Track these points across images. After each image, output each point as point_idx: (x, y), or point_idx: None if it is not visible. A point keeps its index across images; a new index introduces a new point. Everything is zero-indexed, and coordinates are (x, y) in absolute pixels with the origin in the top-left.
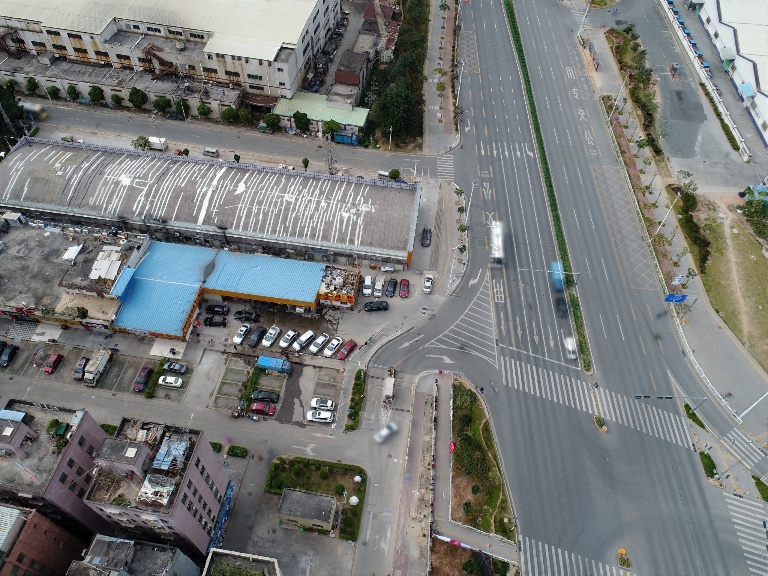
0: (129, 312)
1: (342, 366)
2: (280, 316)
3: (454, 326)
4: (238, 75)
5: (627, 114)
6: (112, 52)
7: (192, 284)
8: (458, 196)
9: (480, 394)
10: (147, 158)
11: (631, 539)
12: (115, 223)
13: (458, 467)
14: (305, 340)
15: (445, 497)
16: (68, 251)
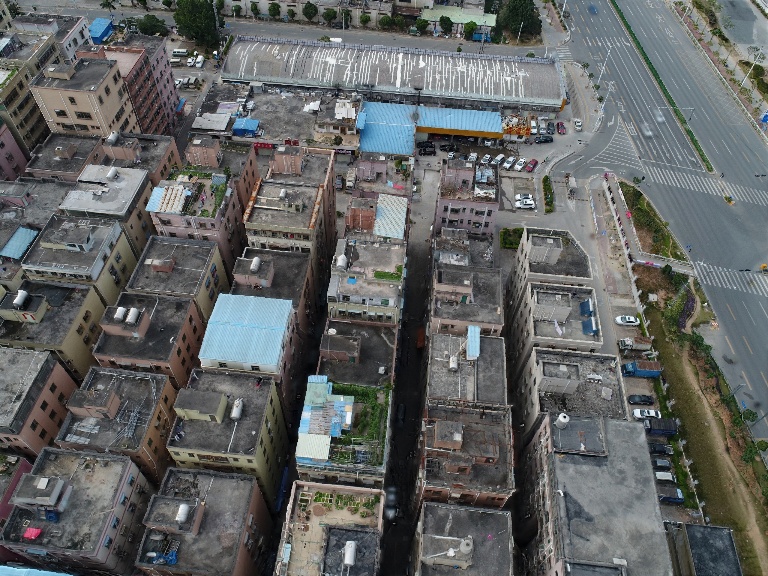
0: (367, 143)
1: (530, 176)
2: (473, 148)
3: (605, 150)
4: None
5: (695, 17)
6: None
7: (407, 125)
8: (584, 69)
9: (638, 187)
10: (338, 48)
11: (767, 261)
12: (329, 91)
13: (638, 224)
14: (500, 159)
15: (633, 242)
16: (306, 107)
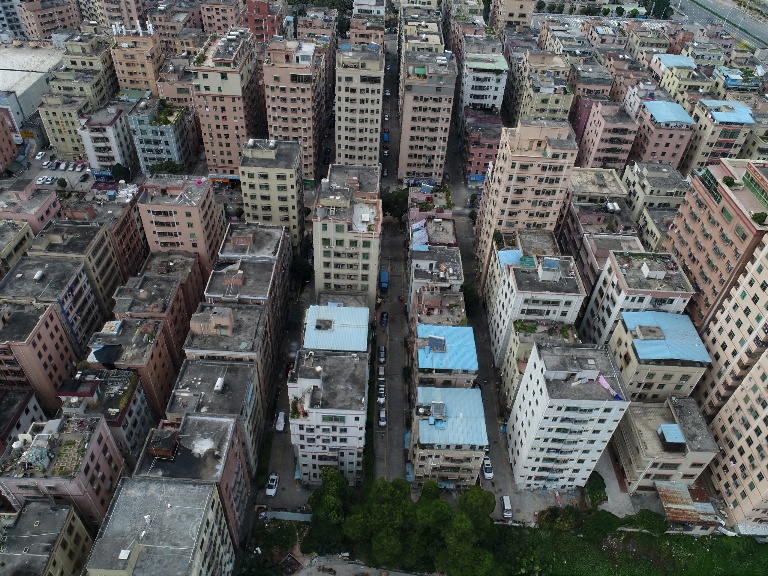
0: None
1: None
2: None
3: None
4: None
5: None
6: None
7: None
8: None
9: None
10: None
11: None
12: None
13: None
14: None
15: None
16: None
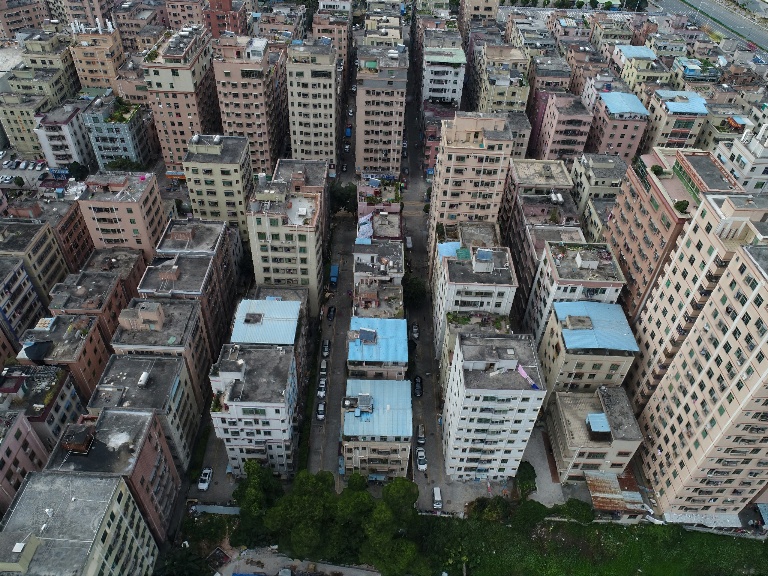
0: None
1: None
2: None
3: None
4: None
5: None
6: None
7: None
8: None
9: None
10: None
11: None
12: None
13: None
14: None
15: None
16: None
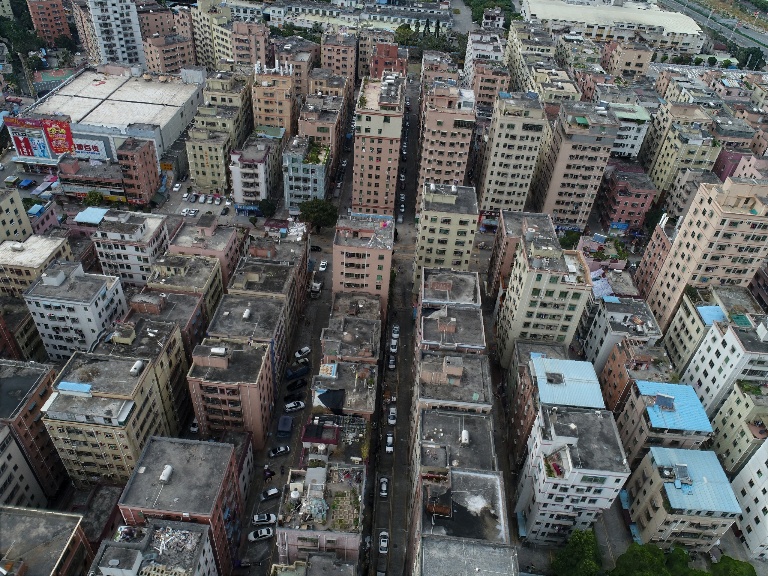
0: None
1: None
2: None
3: None
4: (677, 43)
5: None
6: (616, 35)
7: None
8: None
9: None
10: None
11: None
12: None
13: None
14: None
15: None
16: None
